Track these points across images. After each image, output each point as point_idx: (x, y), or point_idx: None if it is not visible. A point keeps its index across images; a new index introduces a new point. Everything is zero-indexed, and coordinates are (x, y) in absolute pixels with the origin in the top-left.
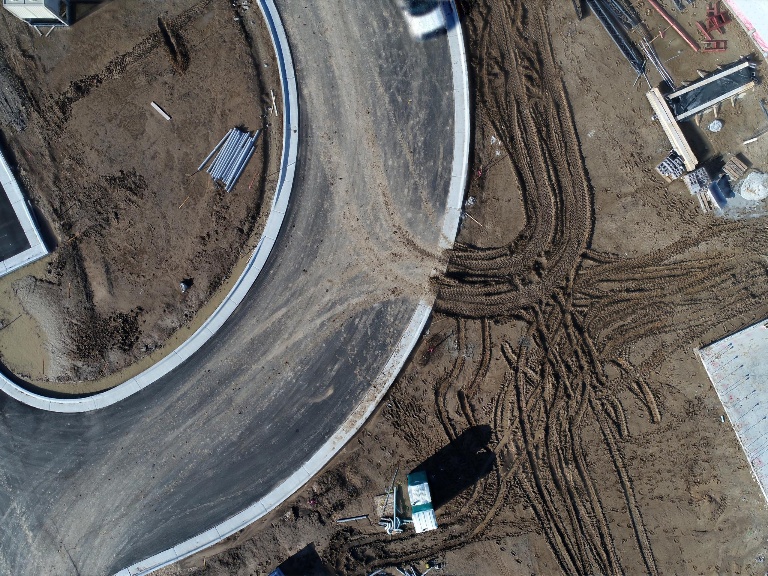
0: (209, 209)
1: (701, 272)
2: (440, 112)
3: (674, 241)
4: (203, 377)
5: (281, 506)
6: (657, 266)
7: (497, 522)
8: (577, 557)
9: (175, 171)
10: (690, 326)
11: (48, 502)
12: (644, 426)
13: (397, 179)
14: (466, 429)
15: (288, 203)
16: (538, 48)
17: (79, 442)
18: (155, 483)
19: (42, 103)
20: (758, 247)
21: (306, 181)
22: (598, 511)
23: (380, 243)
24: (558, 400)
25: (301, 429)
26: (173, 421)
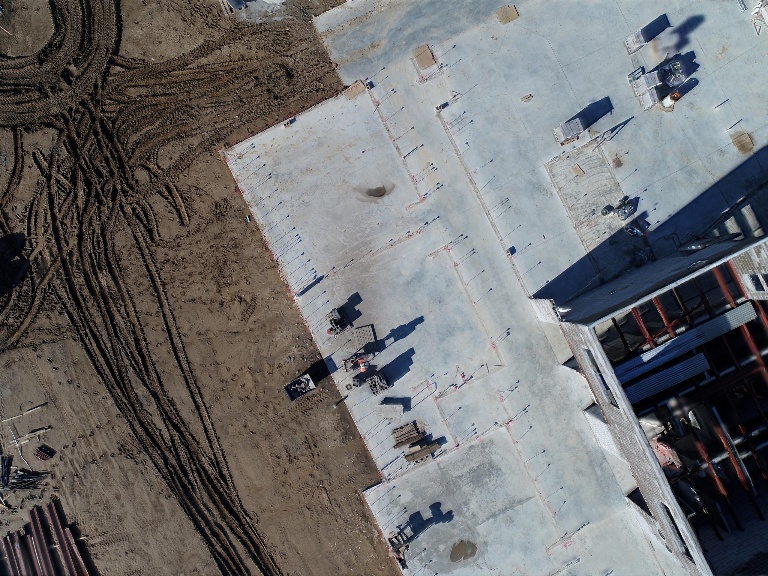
0: None
1: (224, 75)
2: None
3: (198, 45)
4: None
5: None
6: (182, 70)
7: (33, 329)
8: (113, 362)
9: None
10: (215, 128)
11: None
12: (174, 229)
13: None
14: (0, 237)
15: None
16: None
17: None
18: None
19: None
20: (279, 49)
21: None
22: (133, 316)
23: None
24: (90, 206)
25: None
26: None
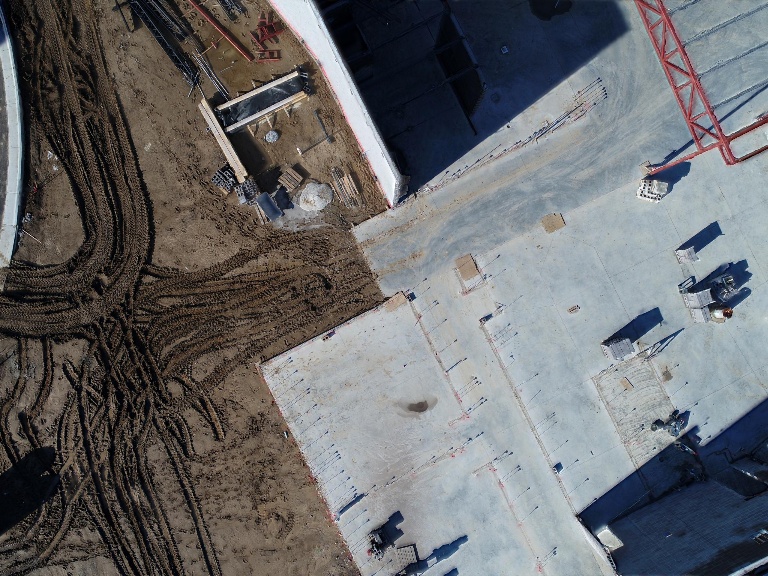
0: None
1: (260, 285)
2: None
3: (233, 254)
4: None
5: None
6: (216, 280)
7: (64, 546)
8: None
9: None
10: (251, 340)
11: None
12: (209, 444)
13: None
14: (29, 451)
15: None
16: (92, 61)
17: None
18: None
19: None
20: (318, 258)
21: None
22: (166, 532)
23: None
24: (122, 419)
25: None
26: None
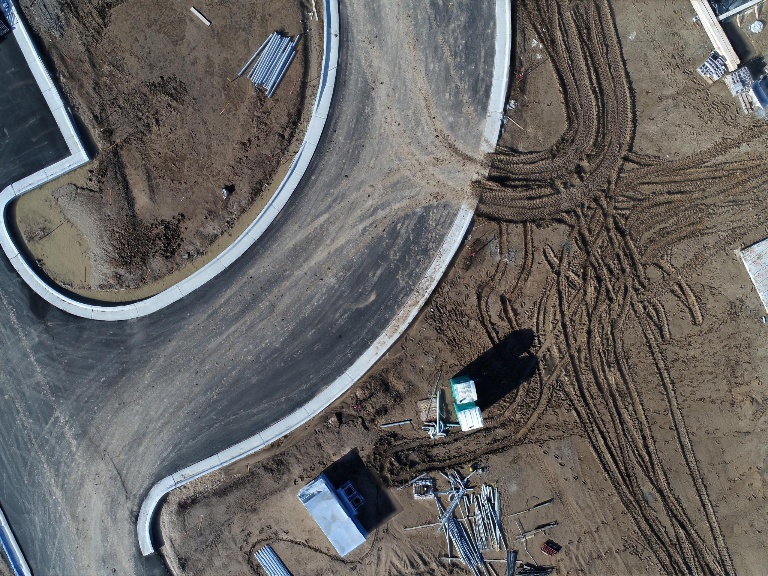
0: (250, 115)
1: (742, 173)
2: (481, 15)
3: (715, 143)
4: (245, 284)
5: (324, 412)
6: (699, 168)
7: (540, 425)
8: (619, 459)
9: (215, 77)
10: (732, 227)
11: (91, 410)
12: (686, 328)
13: (438, 83)
14: (508, 333)
15: (329, 108)
16: None
17: (122, 350)
18: (198, 390)
19: (81, 9)
20: None
21: (347, 86)
22: (640, 413)
23: (422, 147)
24: (600, 303)
25: (344, 335)
26: (216, 328)
